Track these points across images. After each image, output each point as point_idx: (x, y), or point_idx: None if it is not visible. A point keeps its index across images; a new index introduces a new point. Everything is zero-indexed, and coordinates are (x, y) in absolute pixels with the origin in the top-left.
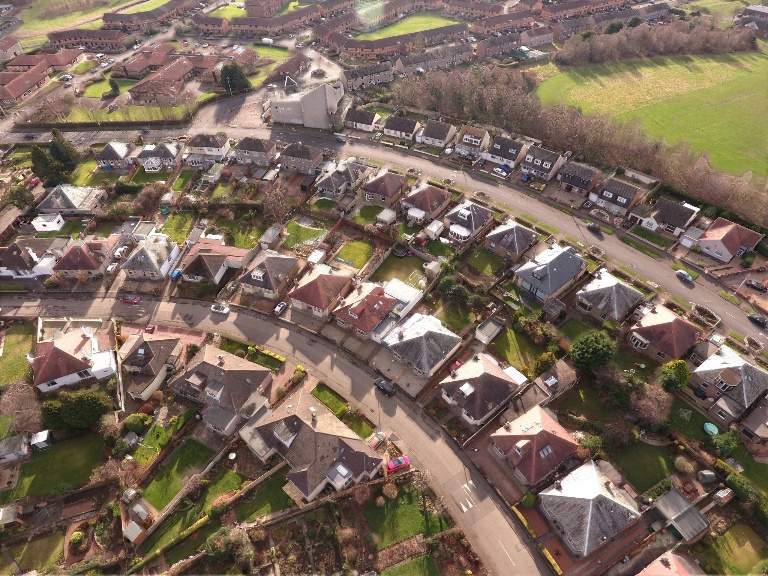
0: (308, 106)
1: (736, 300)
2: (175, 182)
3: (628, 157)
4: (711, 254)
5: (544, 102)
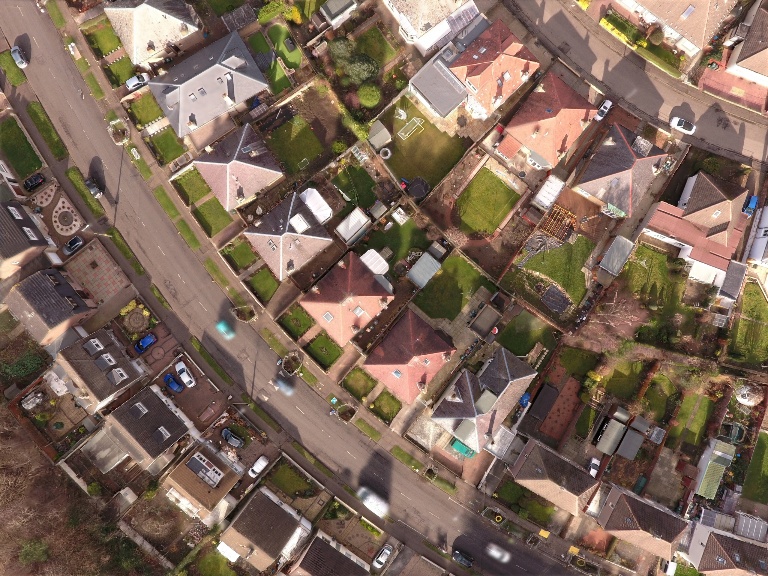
0: None
1: None
2: None
3: None
4: None
5: None
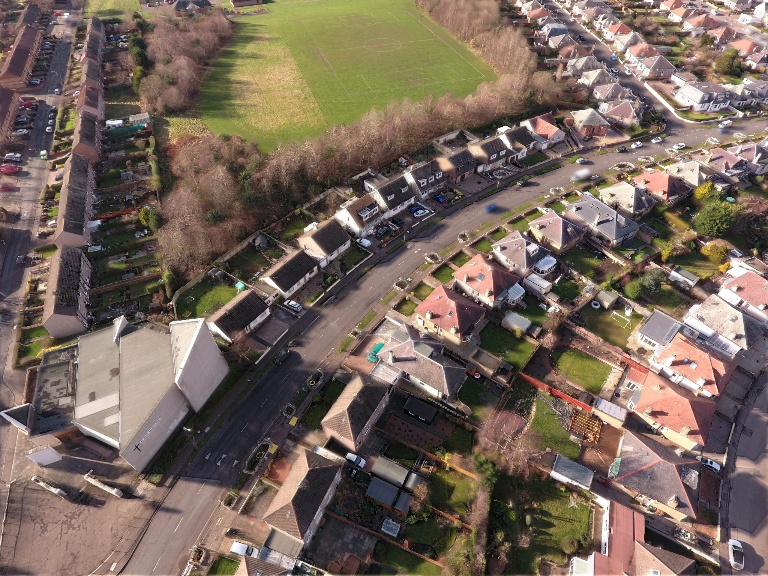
0: (192, 378)
1: (603, 150)
2: None
3: (407, 134)
4: (556, 142)
5: (268, 148)
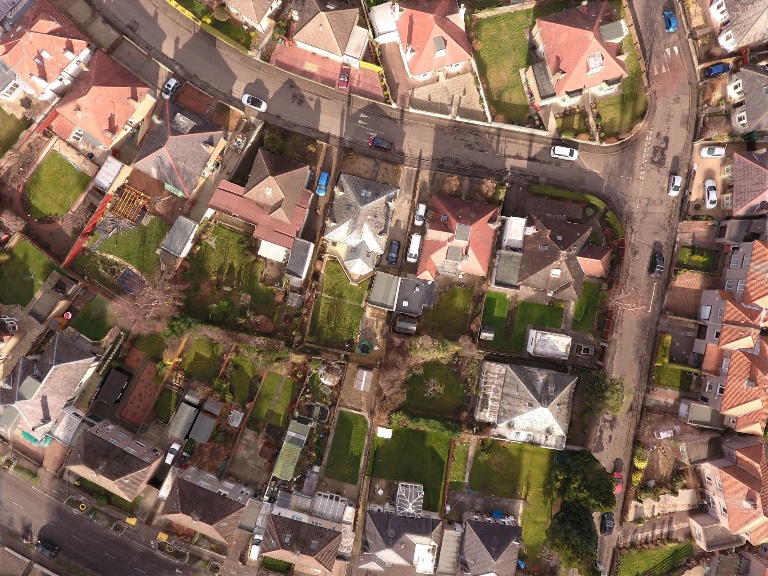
0: None
1: None
2: (365, 443)
3: None
4: None
5: None
